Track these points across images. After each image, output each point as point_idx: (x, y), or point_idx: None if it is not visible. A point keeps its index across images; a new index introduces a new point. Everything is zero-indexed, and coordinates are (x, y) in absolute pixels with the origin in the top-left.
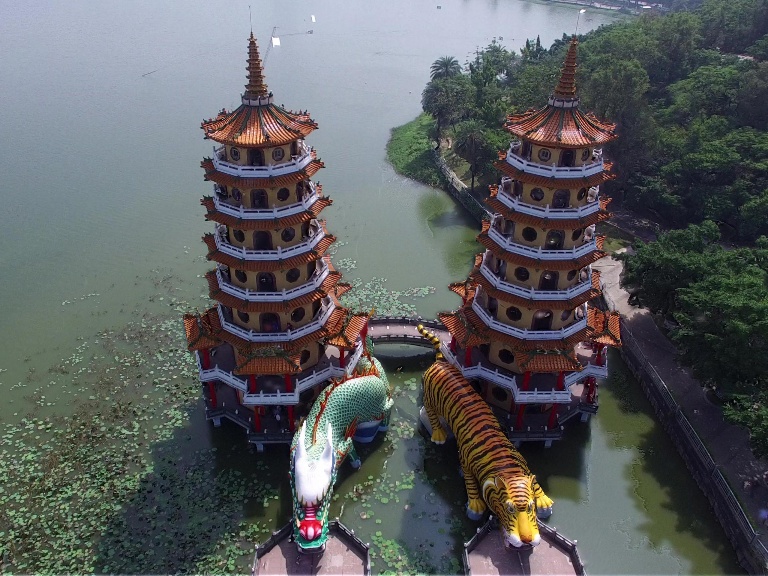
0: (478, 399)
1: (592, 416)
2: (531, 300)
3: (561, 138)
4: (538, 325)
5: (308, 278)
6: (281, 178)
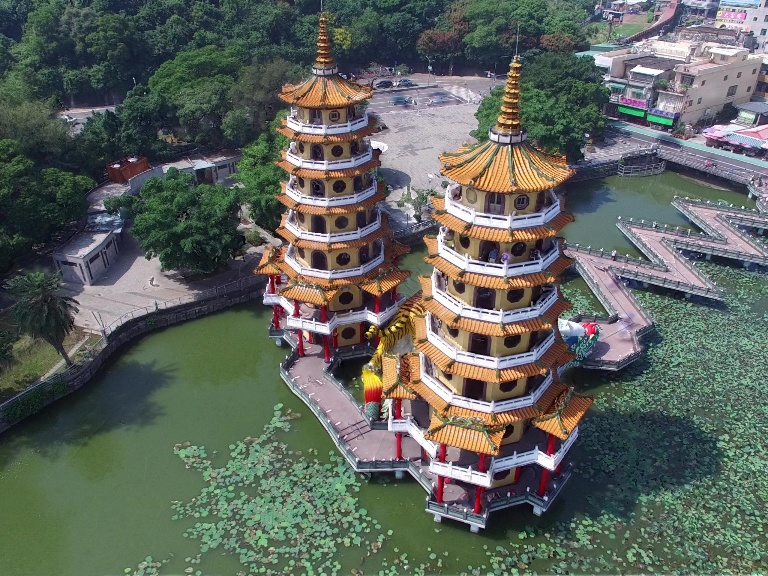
0: None
1: None
2: (382, 214)
3: None
4: None
5: None
6: None
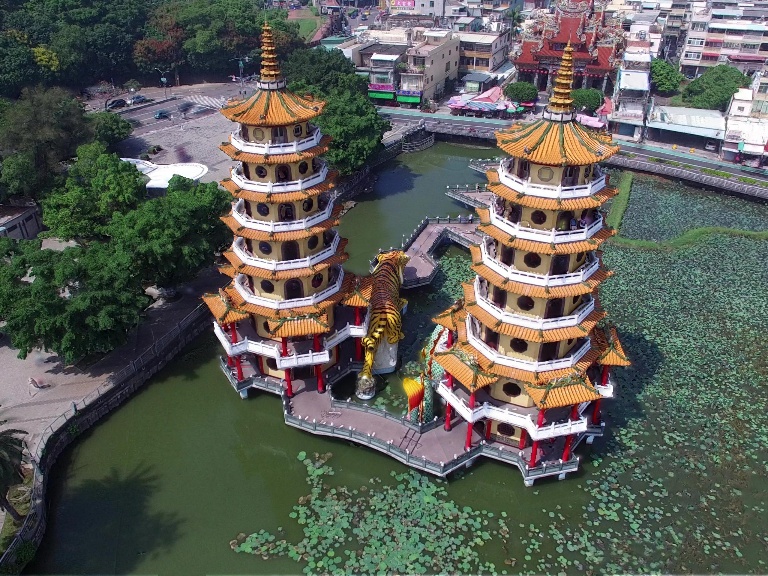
0: None
1: None
2: None
3: None
4: None
5: None
6: None
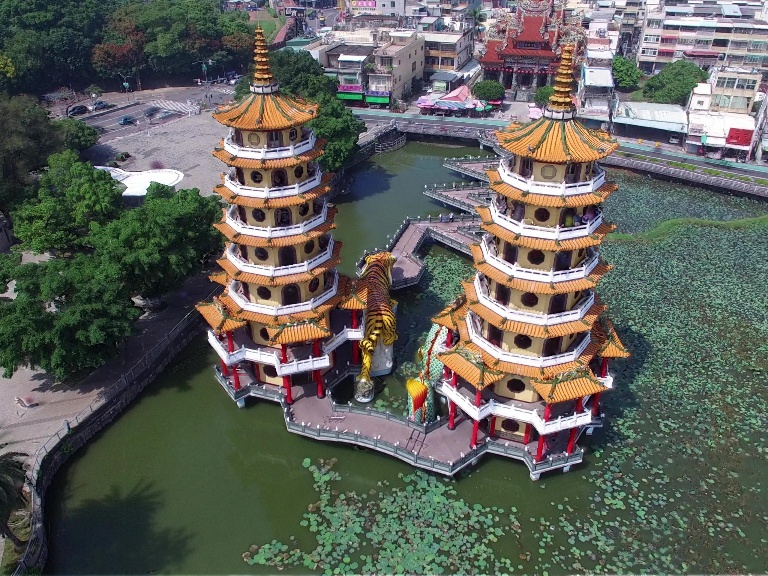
0: None
1: None
2: None
3: None
4: None
5: None
6: None
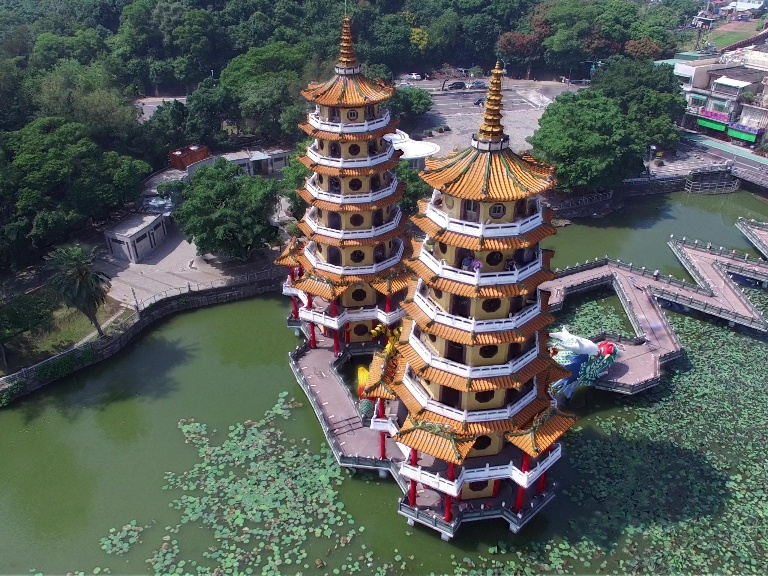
0: None
1: None
2: None
3: None
4: None
5: None
6: None
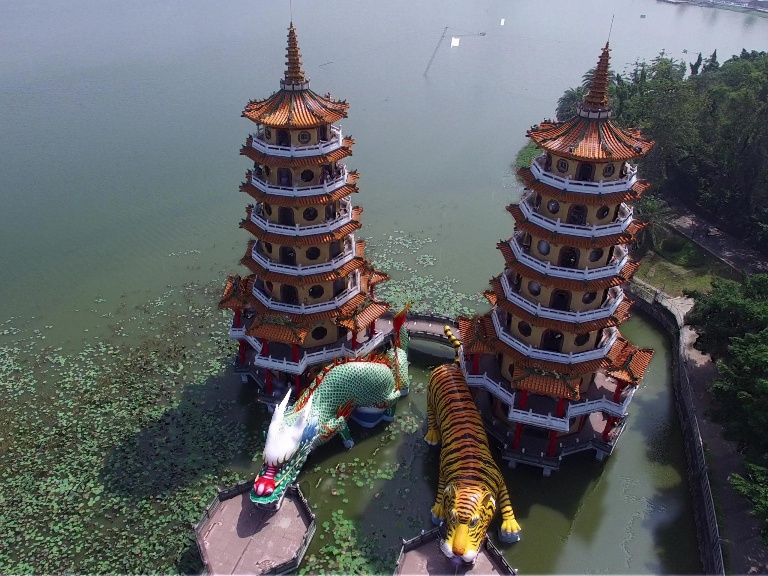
0: (469, 407)
1: (611, 457)
2: (536, 316)
3: (575, 149)
4: (548, 345)
5: (330, 259)
6: (302, 160)
